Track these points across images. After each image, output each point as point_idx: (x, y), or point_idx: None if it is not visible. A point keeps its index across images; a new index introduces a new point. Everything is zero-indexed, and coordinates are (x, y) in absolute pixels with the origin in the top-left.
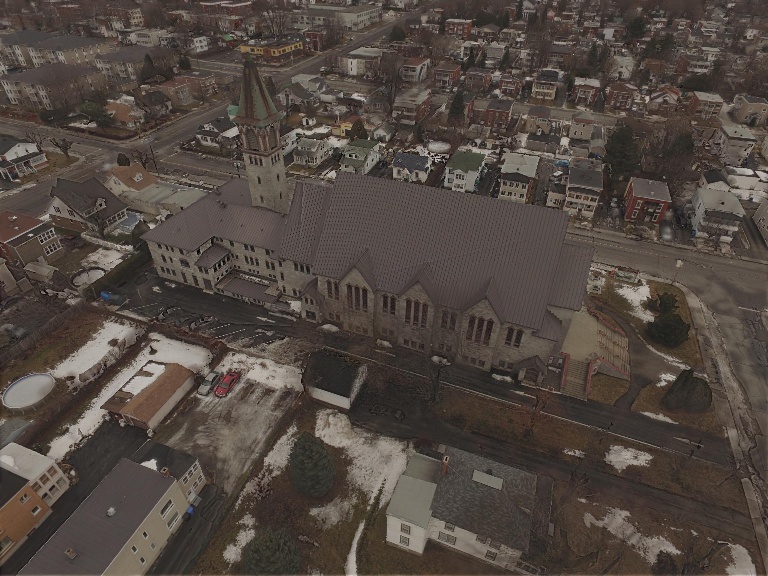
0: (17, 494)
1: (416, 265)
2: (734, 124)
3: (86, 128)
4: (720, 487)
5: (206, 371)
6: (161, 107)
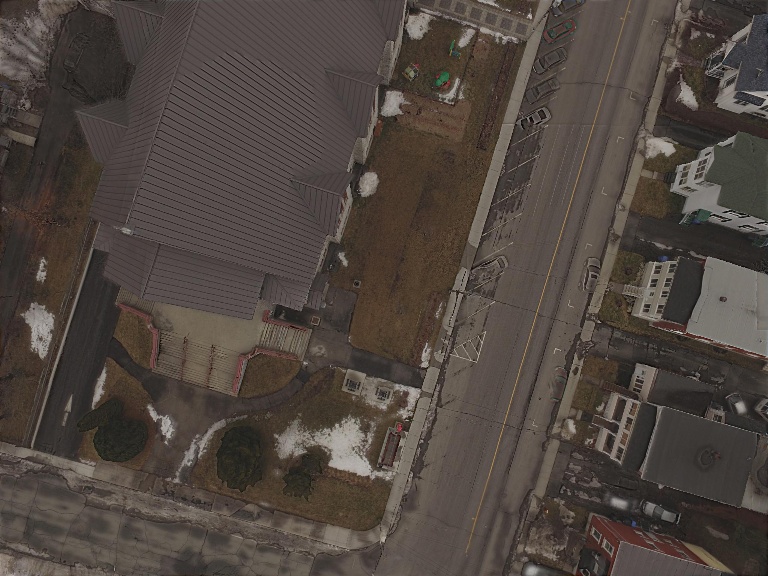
0: None
1: (166, 3)
2: None
3: None
4: (1, 415)
5: None
6: None
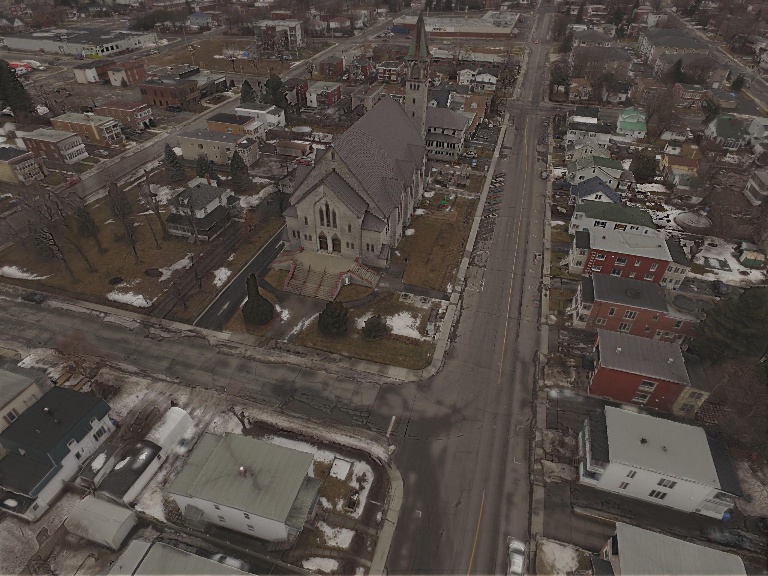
0: (238, 125)
1: None
2: None
3: (559, 90)
4: None
5: (312, 158)
6: (612, 95)
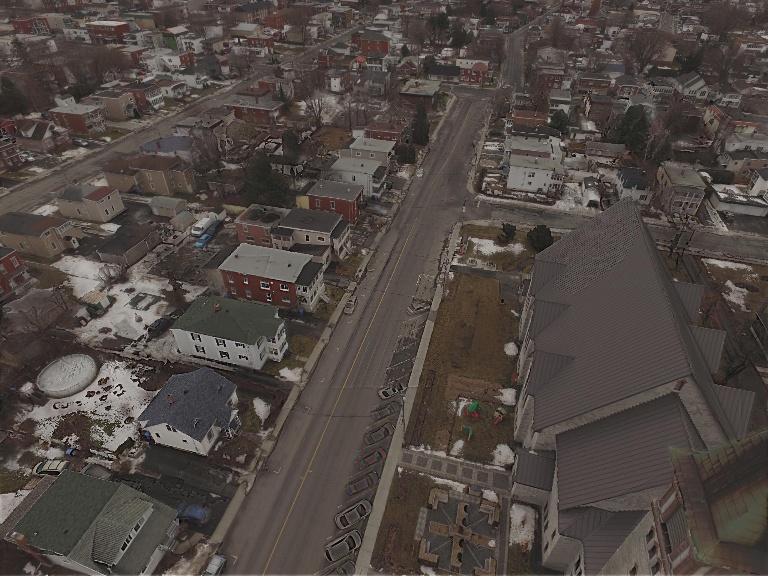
0: None
1: None
2: (125, 123)
3: None
4: None
5: None
6: None
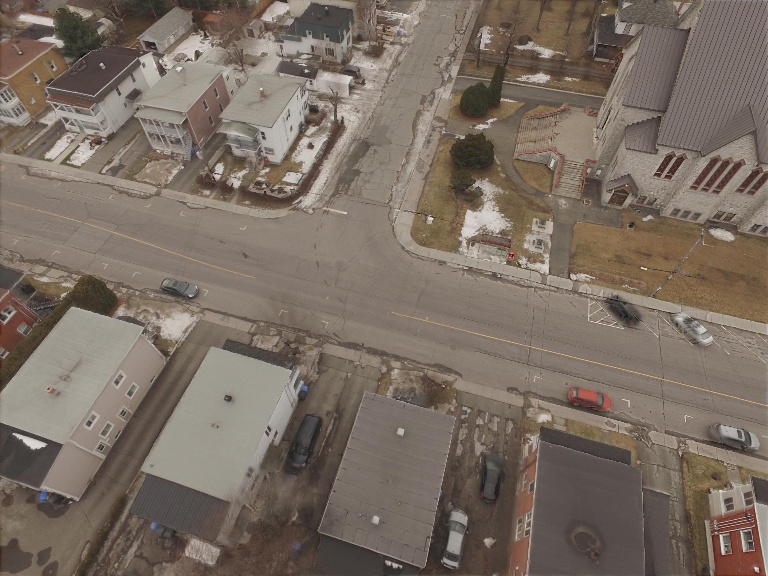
0: None
1: None
2: None
3: None
4: None
5: None
6: None
